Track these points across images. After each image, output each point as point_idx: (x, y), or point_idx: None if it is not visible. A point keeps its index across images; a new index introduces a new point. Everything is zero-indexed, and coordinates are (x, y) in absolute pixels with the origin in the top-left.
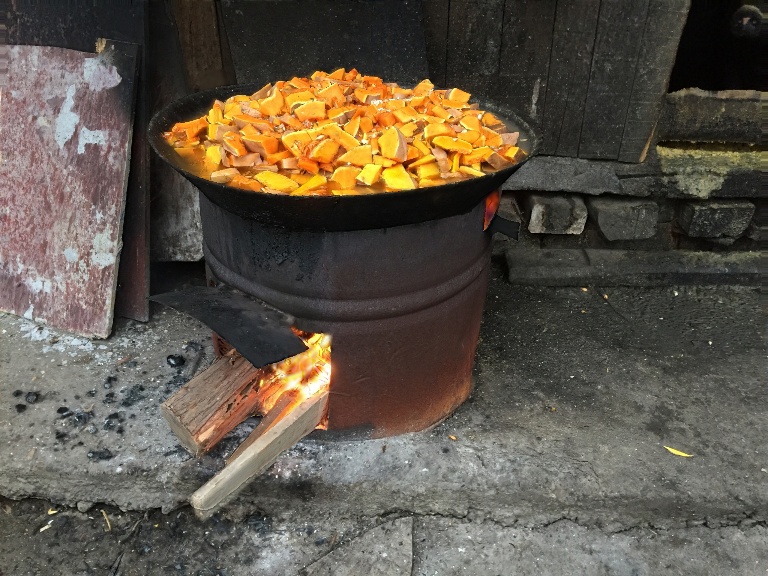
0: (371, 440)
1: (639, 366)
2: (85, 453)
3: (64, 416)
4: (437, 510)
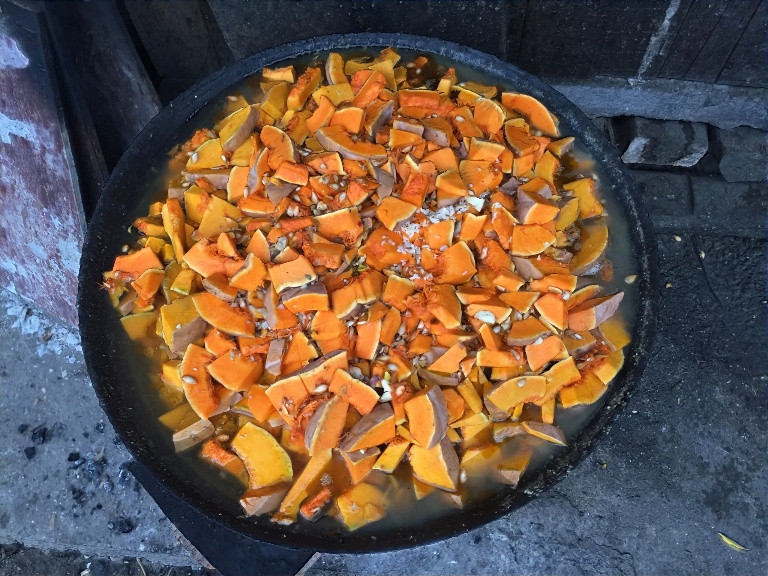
0: None
1: (718, 393)
2: (105, 520)
3: (76, 466)
4: None
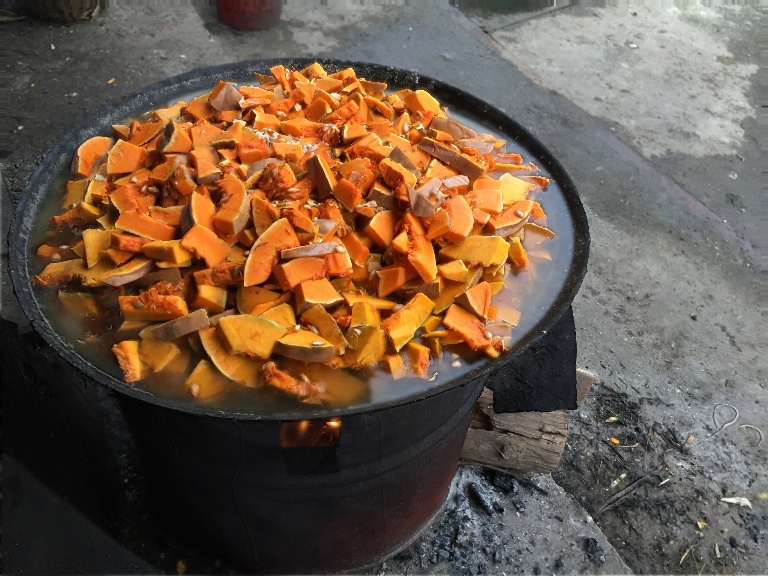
0: None
1: None
2: (604, 570)
3: None
4: None
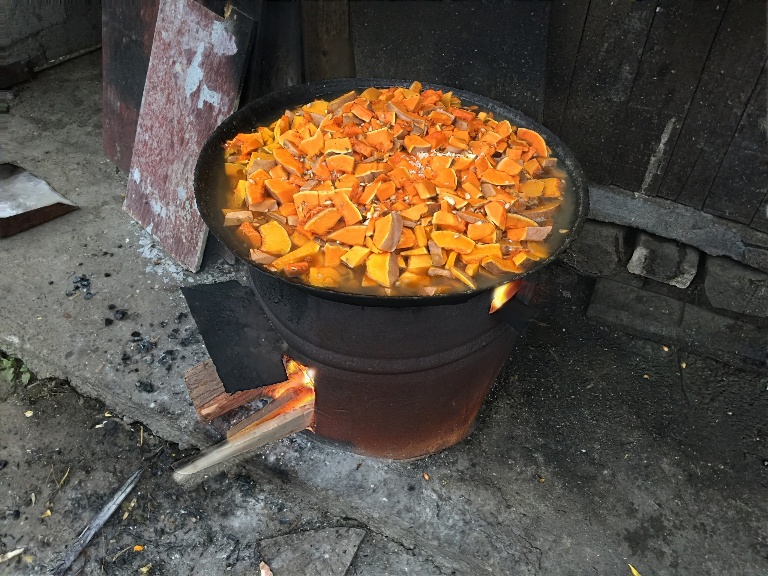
0: (352, 453)
1: (665, 463)
2: (136, 380)
3: (135, 340)
4: (387, 535)
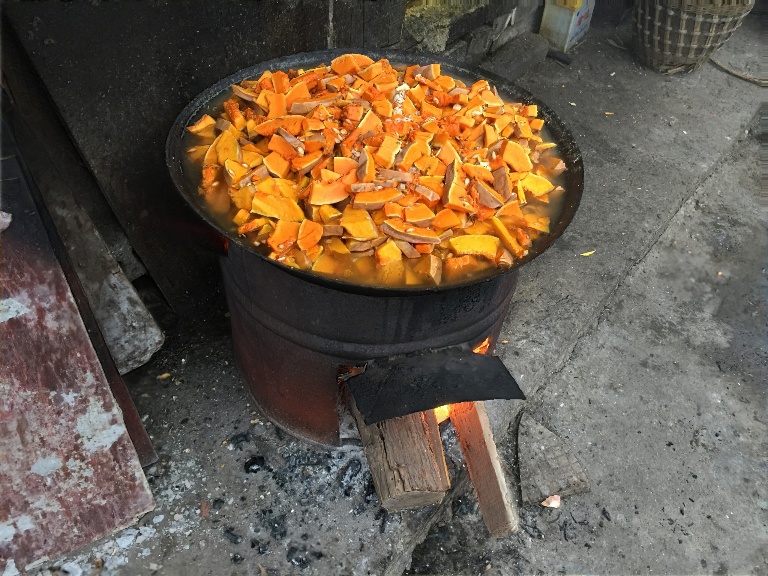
0: None
1: None
2: None
3: None
4: None
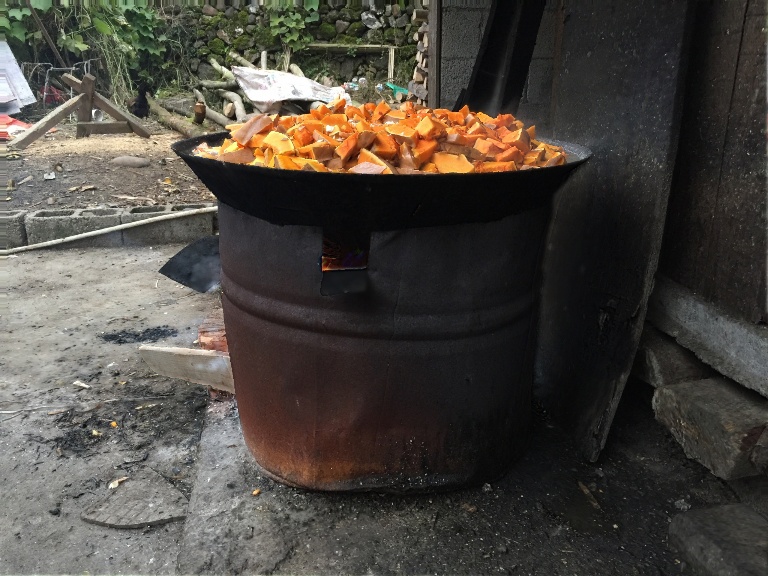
0: None
1: None
2: None
3: None
4: None
